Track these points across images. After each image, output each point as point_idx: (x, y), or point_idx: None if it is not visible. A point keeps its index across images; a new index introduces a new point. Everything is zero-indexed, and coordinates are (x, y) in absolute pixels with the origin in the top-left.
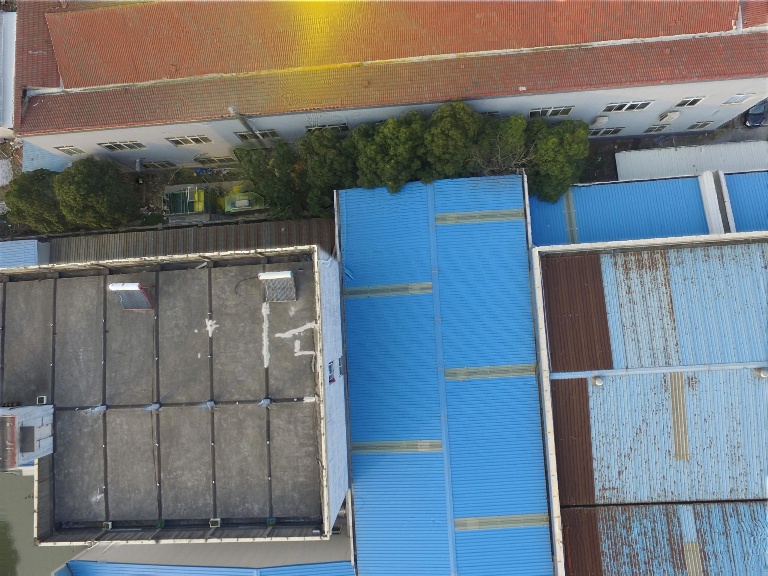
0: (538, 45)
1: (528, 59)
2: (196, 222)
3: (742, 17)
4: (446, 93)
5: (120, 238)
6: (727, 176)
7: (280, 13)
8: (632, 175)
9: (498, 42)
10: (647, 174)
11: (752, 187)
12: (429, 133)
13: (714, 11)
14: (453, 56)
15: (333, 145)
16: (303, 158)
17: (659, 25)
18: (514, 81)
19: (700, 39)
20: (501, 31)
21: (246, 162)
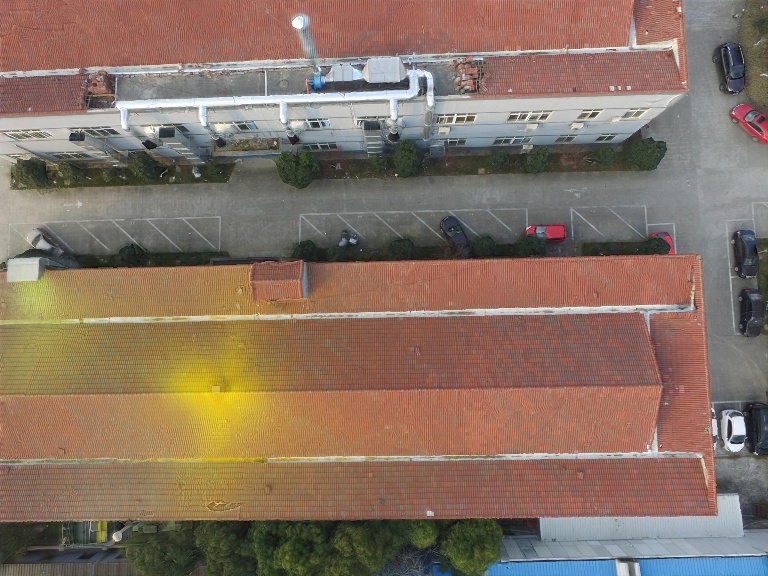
0: (450, 453)
1: (439, 471)
2: (100, 546)
3: (658, 440)
4: (351, 512)
5: (14, 570)
6: (644, 561)
7: (176, 413)
8: (554, 527)
9: (409, 449)
10: (569, 526)
11: (668, 575)
12: (329, 569)
13: (629, 437)
14: (362, 458)
15: (232, 552)
16: (202, 550)
17: (574, 445)
18: (422, 502)
19: (615, 461)
20: (412, 441)
21: (138, 563)
